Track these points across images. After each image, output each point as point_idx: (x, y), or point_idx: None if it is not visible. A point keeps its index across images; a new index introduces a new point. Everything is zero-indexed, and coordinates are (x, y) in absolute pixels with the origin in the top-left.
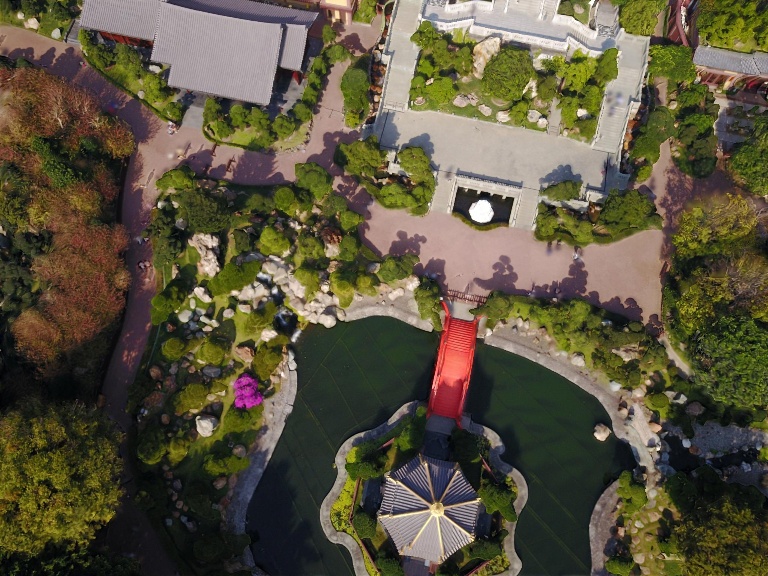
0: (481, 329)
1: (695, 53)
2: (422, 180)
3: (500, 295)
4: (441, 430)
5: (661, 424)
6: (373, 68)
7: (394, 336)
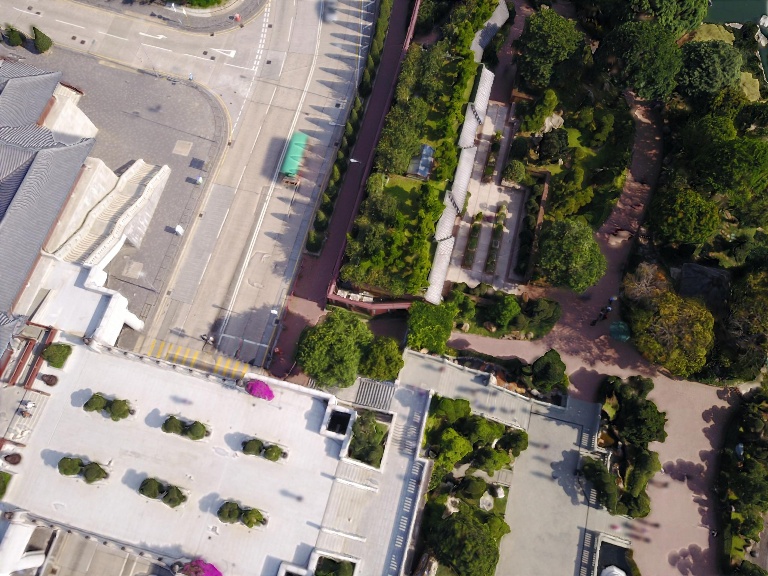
0: None
1: (429, 301)
2: None
3: None
4: None
5: None
6: None
7: None
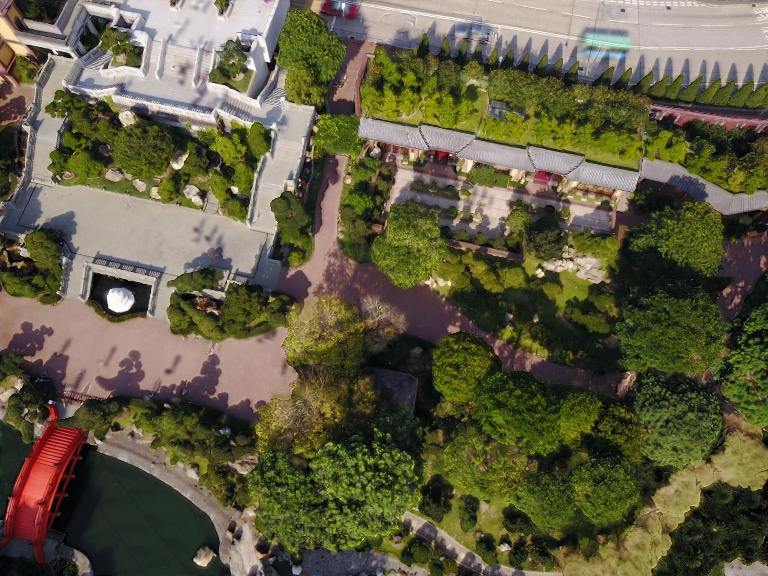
0: (91, 436)
1: (359, 125)
2: (47, 267)
3: (89, 405)
4: (21, 555)
5: (272, 547)
6: (20, 138)
7: (2, 442)
